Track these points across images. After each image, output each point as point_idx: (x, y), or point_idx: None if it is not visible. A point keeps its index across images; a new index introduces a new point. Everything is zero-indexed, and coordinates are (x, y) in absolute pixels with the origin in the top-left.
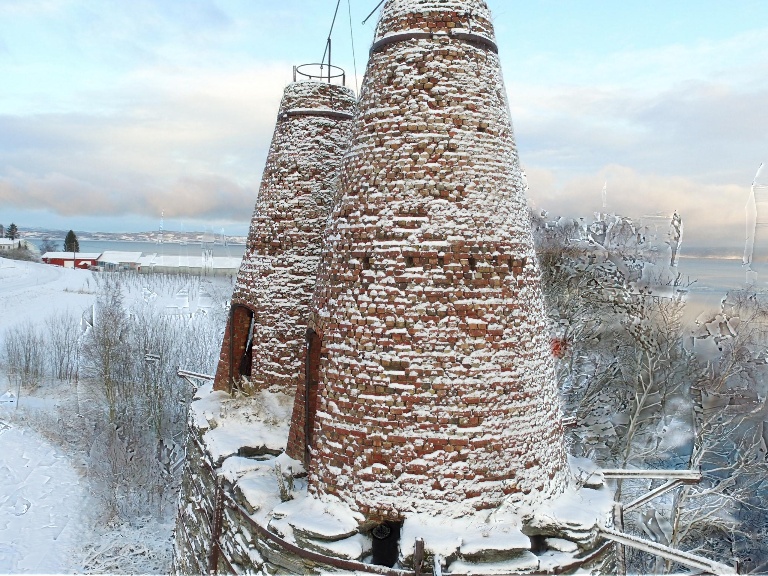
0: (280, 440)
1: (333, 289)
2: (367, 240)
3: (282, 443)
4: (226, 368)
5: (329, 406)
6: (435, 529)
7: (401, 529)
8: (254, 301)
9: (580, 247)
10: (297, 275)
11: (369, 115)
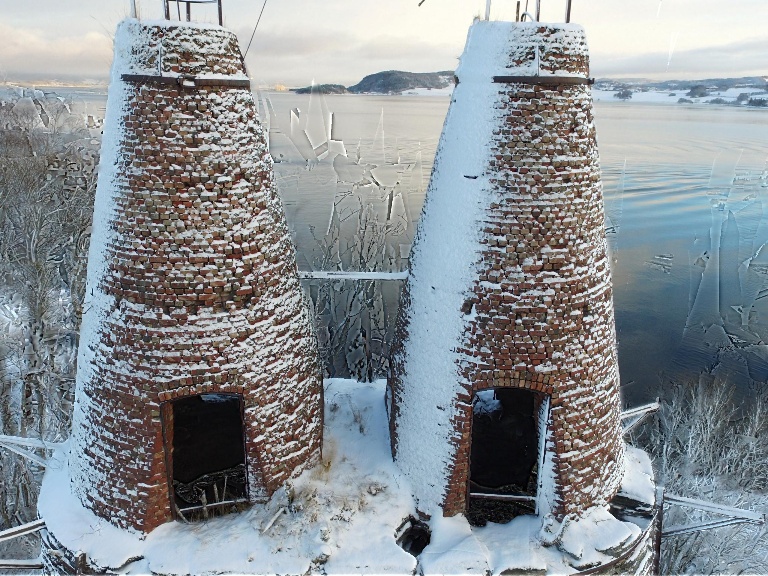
0: (396, 514)
1: (557, 343)
2: (581, 290)
3: (401, 515)
4: (163, 492)
5: (575, 444)
6: (635, 478)
7: (624, 494)
8: (238, 381)
9: (77, 145)
10: (282, 324)
11: (560, 163)
